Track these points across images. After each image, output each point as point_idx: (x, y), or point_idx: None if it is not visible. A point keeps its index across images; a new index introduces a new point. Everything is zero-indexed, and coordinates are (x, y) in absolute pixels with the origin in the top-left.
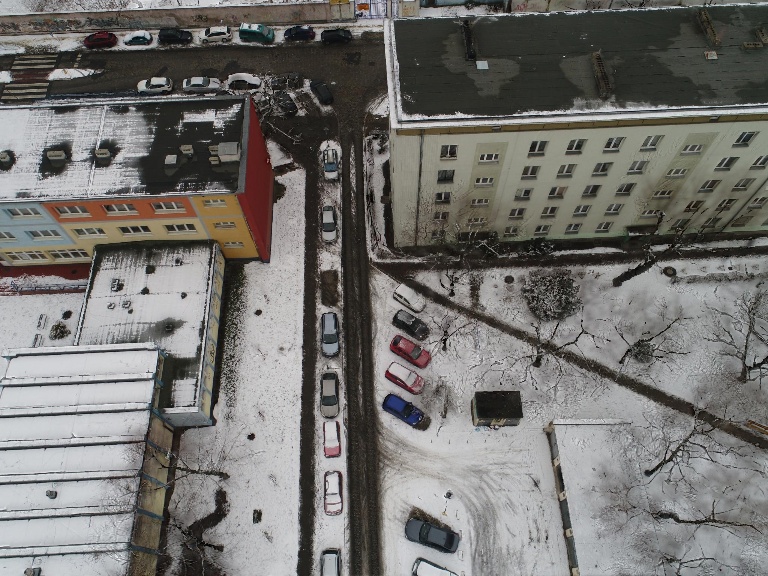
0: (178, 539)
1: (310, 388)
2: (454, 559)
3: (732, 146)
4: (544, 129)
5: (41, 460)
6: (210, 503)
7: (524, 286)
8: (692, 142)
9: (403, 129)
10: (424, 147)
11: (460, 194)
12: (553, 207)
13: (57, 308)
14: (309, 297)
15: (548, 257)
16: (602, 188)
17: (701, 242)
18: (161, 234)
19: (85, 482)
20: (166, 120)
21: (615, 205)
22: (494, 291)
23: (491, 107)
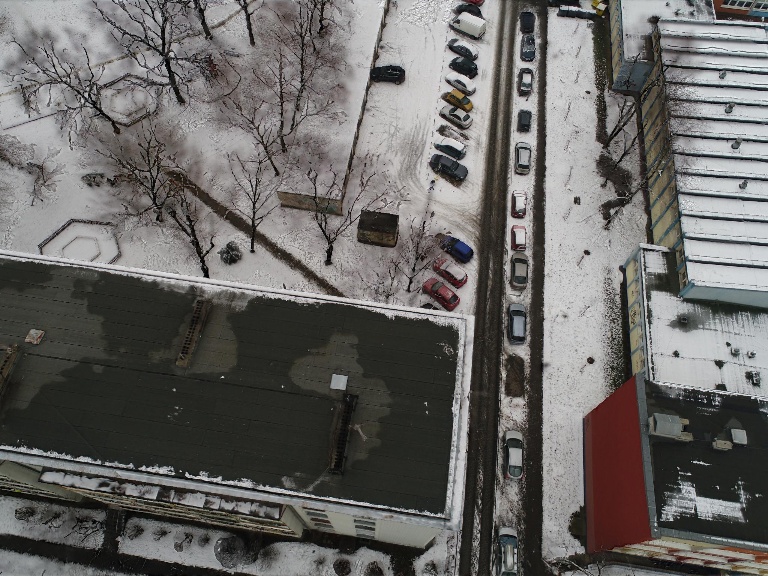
0: (636, 197)
1: (537, 282)
2: None
3: None
4: None
5: (762, 210)
6: None
7: None
8: None
9: None
10: None
11: None
12: None
13: None
14: (537, 369)
15: None
16: None
17: None
18: None
19: None
20: (767, 512)
21: None
22: None
23: (349, 317)
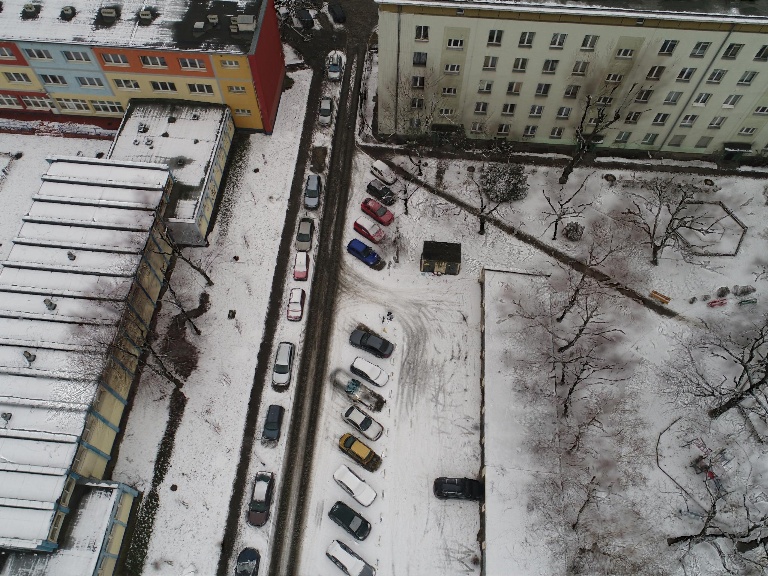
0: (166, 323)
1: (290, 230)
2: (387, 363)
3: (658, 54)
4: (499, 18)
5: (66, 234)
6: (195, 301)
7: (482, 173)
8: (624, 46)
9: (384, 3)
10: (401, 26)
11: (432, 80)
12: (512, 105)
13: (92, 150)
14: (300, 164)
15: (507, 156)
16: (552, 88)
17: (642, 158)
18: (184, 93)
19: (98, 253)
20: None
21: (565, 110)
22: (456, 176)
23: None
